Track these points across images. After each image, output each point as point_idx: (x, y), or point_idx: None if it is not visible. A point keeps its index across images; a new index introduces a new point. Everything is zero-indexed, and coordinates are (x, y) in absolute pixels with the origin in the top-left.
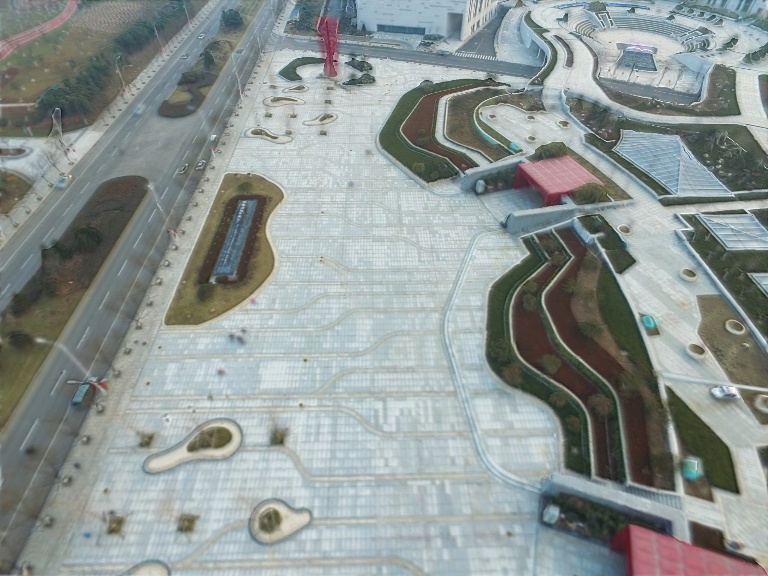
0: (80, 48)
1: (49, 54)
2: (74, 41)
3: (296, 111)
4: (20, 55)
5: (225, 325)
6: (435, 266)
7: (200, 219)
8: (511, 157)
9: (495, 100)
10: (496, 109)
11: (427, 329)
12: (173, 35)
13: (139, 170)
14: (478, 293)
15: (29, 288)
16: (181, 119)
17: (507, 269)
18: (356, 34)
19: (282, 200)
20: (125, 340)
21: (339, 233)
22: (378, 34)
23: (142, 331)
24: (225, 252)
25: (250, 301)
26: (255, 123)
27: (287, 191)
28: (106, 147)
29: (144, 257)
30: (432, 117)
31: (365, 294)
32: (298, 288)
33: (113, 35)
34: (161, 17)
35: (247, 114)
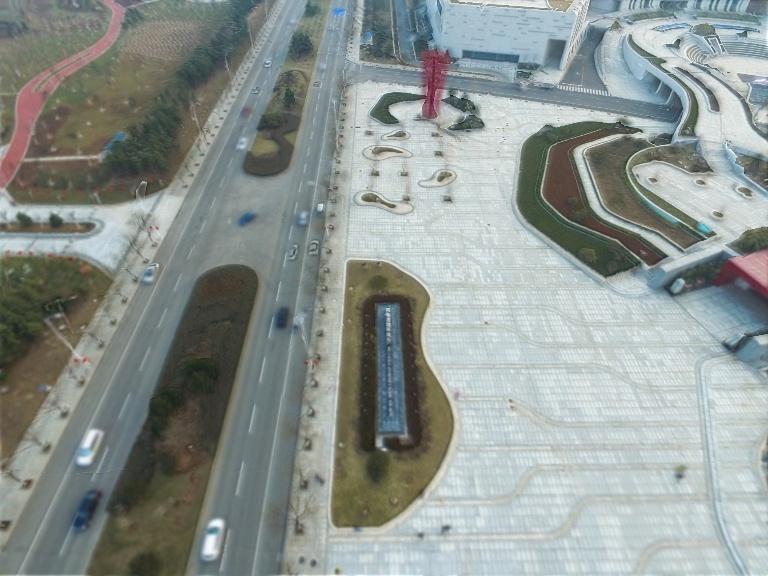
0: (137, 81)
1: (103, 89)
2: (128, 71)
3: (406, 167)
4: (69, 90)
5: (417, 527)
6: (666, 417)
7: (334, 334)
8: (704, 243)
9: (644, 156)
10: (651, 169)
11: (700, 536)
12: (239, 64)
13: (239, 255)
14: (745, 468)
15: (137, 459)
16: (272, 178)
17: (767, 425)
18: (439, 61)
19: (429, 303)
20: (286, 557)
21: (519, 358)
22: (464, 61)
23: (305, 538)
24: (384, 393)
25: (440, 481)
26: (362, 184)
27: (431, 288)
28: (191, 219)
29: (277, 399)
30: (574, 178)
31: (591, 468)
32: (497, 457)
33: (170, 64)
34: (221, 41)
35: (349, 171)
